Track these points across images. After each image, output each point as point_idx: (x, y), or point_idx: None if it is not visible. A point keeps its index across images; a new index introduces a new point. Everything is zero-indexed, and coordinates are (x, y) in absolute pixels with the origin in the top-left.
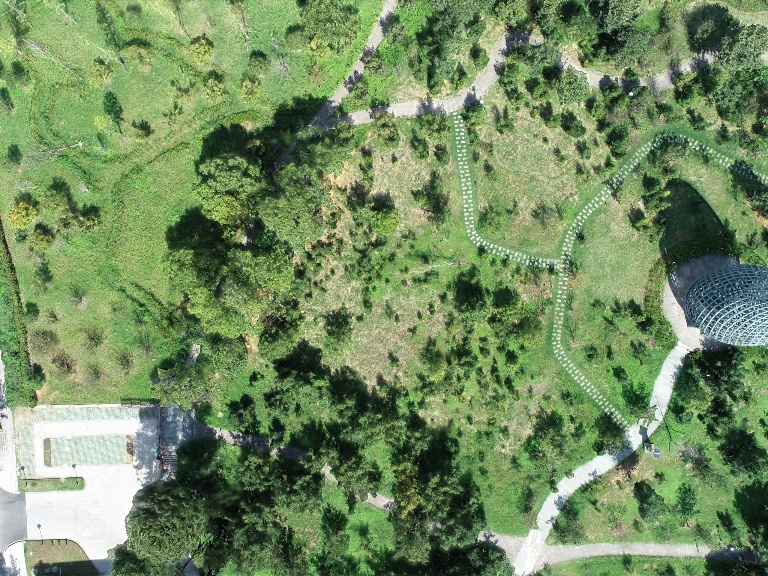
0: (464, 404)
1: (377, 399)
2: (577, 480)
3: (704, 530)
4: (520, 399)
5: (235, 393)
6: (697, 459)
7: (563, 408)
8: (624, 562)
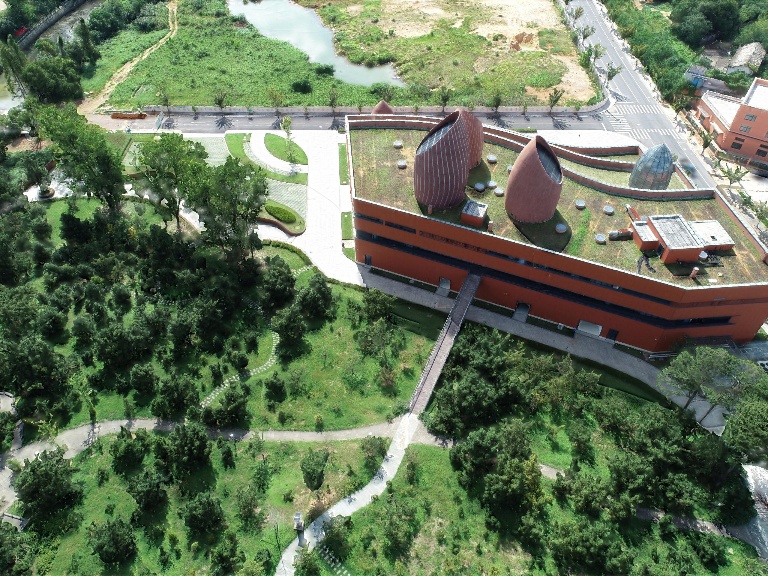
0: (488, 568)
1: (578, 571)
2: (366, 494)
3: (255, 450)
4: (429, 575)
5: (727, 574)
6: (249, 516)
7: (384, 566)
8: (322, 425)
